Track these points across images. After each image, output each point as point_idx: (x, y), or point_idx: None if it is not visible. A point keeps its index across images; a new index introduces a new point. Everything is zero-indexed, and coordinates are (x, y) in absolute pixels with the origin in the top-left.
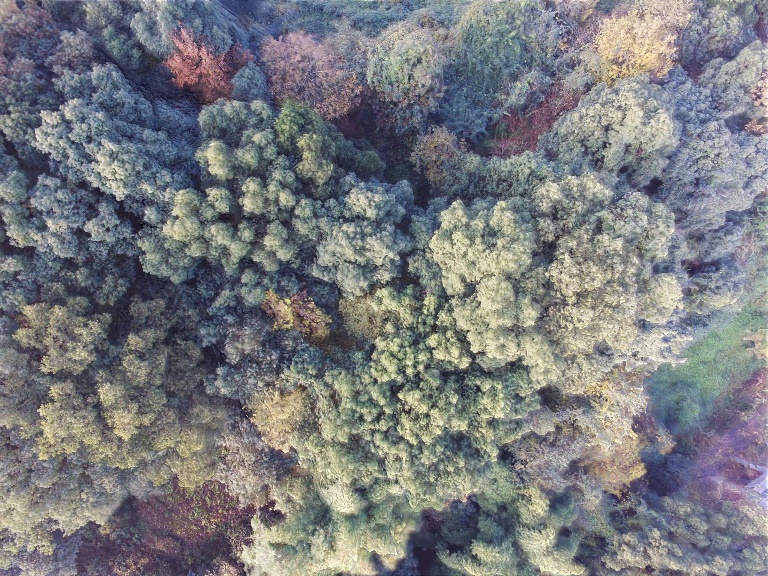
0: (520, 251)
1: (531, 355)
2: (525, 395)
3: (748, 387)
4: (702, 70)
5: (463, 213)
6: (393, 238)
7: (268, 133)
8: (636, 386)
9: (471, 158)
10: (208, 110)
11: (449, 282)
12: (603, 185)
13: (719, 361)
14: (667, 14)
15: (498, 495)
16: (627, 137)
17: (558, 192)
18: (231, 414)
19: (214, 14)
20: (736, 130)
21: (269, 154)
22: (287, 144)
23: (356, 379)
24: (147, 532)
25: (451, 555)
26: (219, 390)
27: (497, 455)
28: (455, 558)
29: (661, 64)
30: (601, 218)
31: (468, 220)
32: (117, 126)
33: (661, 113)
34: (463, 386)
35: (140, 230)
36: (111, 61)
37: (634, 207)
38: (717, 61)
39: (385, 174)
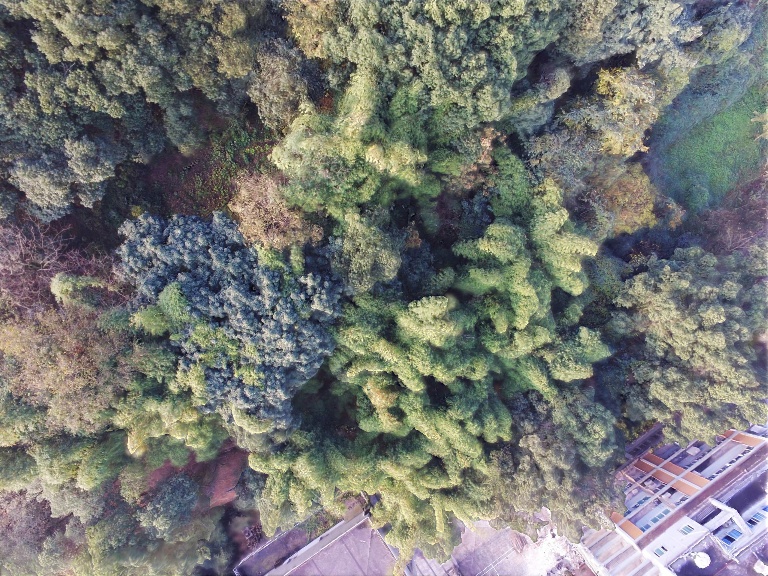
0: None
1: None
2: (544, 17)
3: (757, 185)
4: None
5: None
6: None
7: None
8: None
9: None
10: None
11: None
12: None
13: (728, 153)
14: None
15: (513, 195)
16: None
17: None
18: (267, 34)
19: None
20: None
21: None
22: None
23: None
24: None
25: (467, 242)
26: None
27: (513, 153)
28: (471, 243)
29: None
30: None
31: None
32: None
33: None
34: None
35: None
36: None
37: None
38: None
39: None
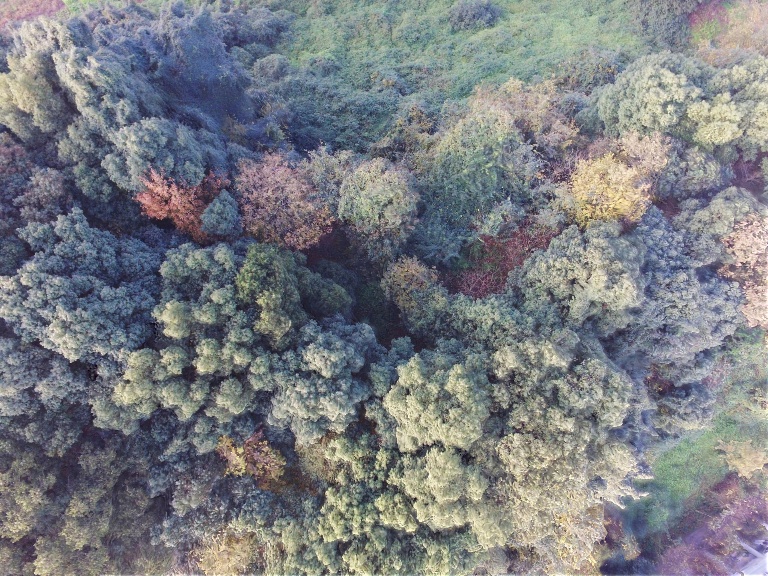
0: (470, 429)
1: (477, 527)
2: None
3: (720, 490)
4: (678, 209)
5: (419, 374)
6: (348, 394)
7: (227, 292)
8: (595, 520)
9: (437, 297)
10: (170, 261)
11: (402, 441)
12: (561, 354)
13: (691, 465)
14: (643, 158)
15: None
16: (591, 295)
17: (514, 363)
18: (181, 549)
19: (188, 147)
20: (707, 275)
21: (227, 312)
22: (247, 299)
23: (303, 533)
24: None
25: None
26: (164, 542)
27: None
28: None
29: (635, 208)
30: (557, 386)
31: (424, 381)
32: (75, 284)
33: (625, 278)
34: (411, 543)
35: (92, 390)
36: (78, 205)
37: (591, 375)
38: (693, 203)
39: (356, 292)
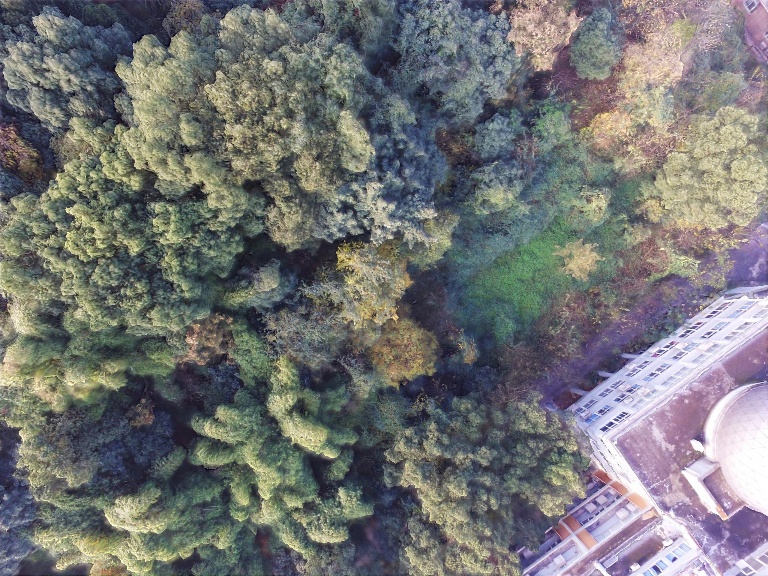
0: (173, 66)
1: (193, 174)
2: (221, 233)
3: None
4: None
5: (147, 42)
6: (80, 65)
7: None
8: (383, 260)
9: (202, 16)
10: None
11: (134, 110)
12: (283, 21)
13: (538, 280)
14: None
15: (255, 368)
16: None
17: (232, 22)
18: None
19: None
20: (477, 9)
21: None
22: None
23: (36, 199)
24: None
25: (198, 421)
26: None
27: (252, 327)
28: (201, 424)
29: None
30: (282, 54)
31: None
32: None
33: None
34: (147, 214)
35: None
36: None
37: (318, 47)
38: None
39: None
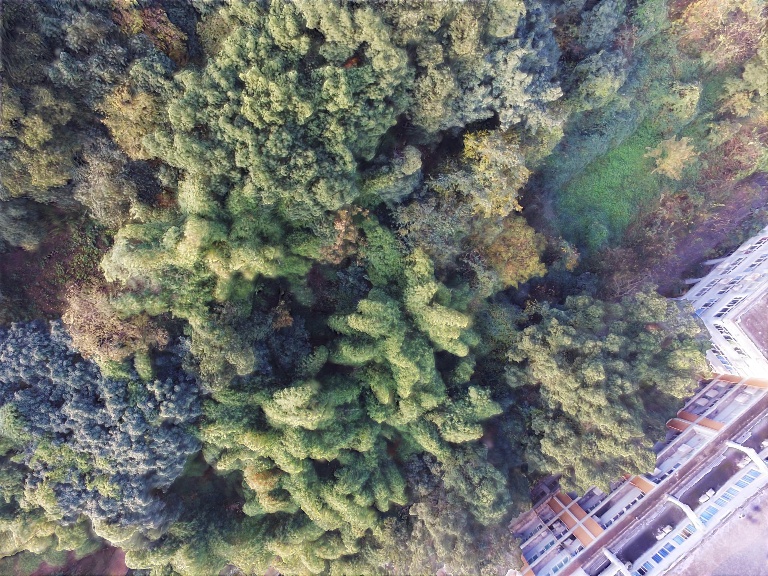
0: None
1: (365, 30)
2: (378, 104)
3: None
4: None
5: None
6: None
7: None
8: (511, 144)
9: None
10: None
11: None
12: None
13: (626, 187)
14: None
15: (386, 265)
16: None
17: None
18: (92, 134)
19: None
20: None
21: None
22: None
23: (203, 73)
24: (39, 313)
25: (339, 319)
26: (63, 75)
27: (383, 223)
28: (342, 321)
29: None
30: None
31: None
32: None
33: None
34: (311, 83)
35: None
36: None
37: None
38: None
39: None
